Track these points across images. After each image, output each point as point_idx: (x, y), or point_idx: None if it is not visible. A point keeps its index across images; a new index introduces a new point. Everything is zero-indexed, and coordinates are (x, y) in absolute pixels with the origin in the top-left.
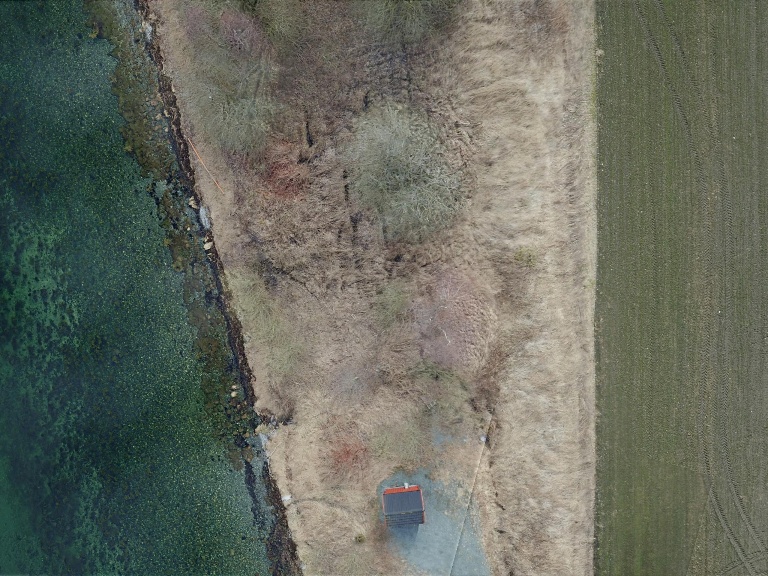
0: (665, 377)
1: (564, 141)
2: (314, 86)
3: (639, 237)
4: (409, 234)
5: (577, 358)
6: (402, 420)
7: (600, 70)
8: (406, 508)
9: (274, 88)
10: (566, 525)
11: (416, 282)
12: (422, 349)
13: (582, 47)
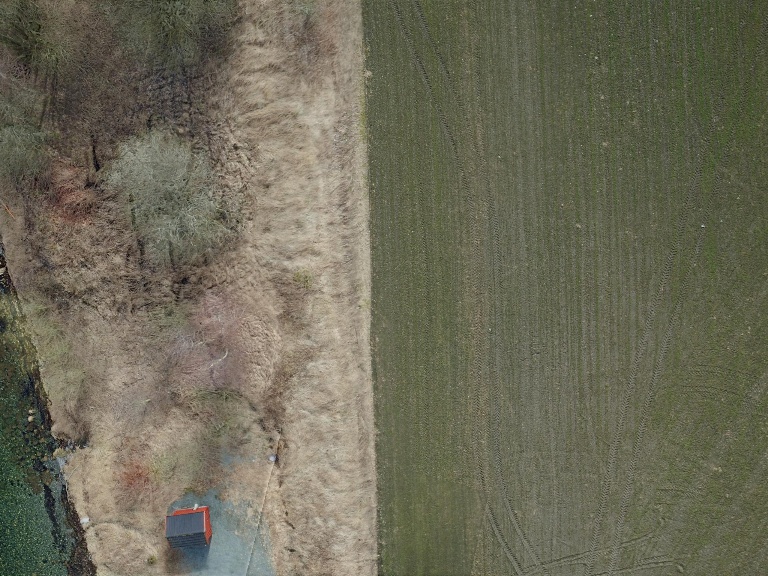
0: (440, 395)
1: (336, 162)
2: (99, 110)
3: (411, 256)
4: (194, 257)
5: (354, 377)
6: (192, 442)
7: (369, 91)
8: (187, 530)
9: (61, 113)
10: (350, 543)
11: (203, 304)
12: (212, 370)
13: (350, 69)
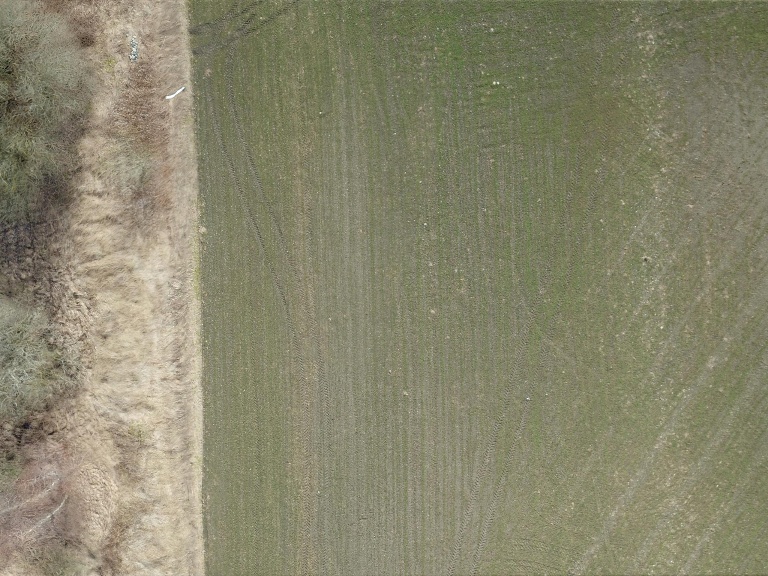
0: (269, 555)
1: (170, 318)
2: None
3: (242, 415)
4: (35, 402)
5: (185, 534)
6: None
7: (203, 248)
8: None
9: None
10: None
11: (44, 450)
12: (53, 515)
13: (185, 224)
